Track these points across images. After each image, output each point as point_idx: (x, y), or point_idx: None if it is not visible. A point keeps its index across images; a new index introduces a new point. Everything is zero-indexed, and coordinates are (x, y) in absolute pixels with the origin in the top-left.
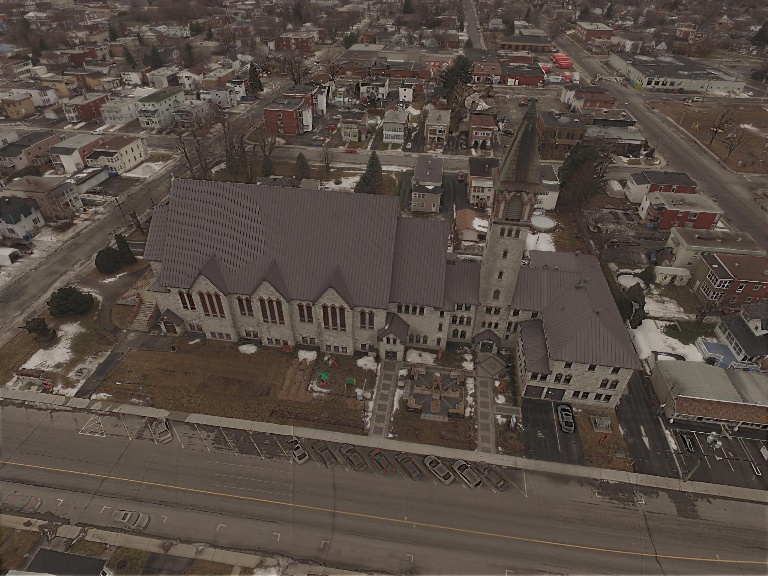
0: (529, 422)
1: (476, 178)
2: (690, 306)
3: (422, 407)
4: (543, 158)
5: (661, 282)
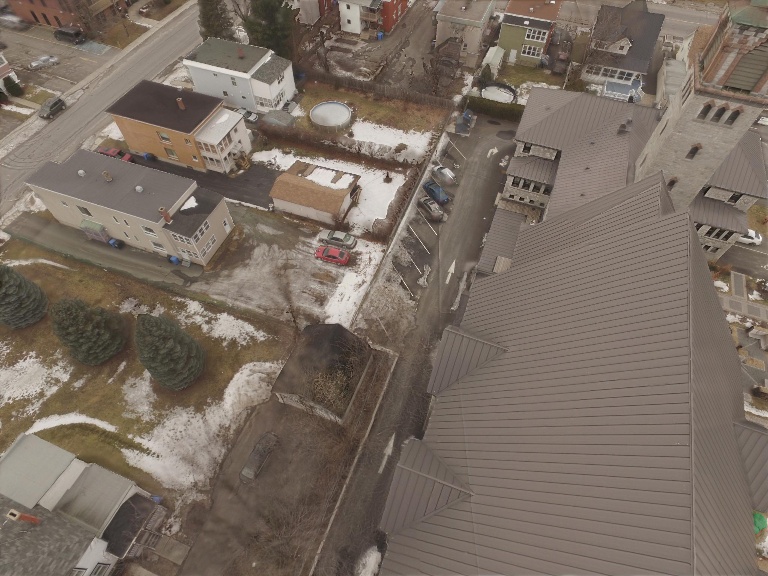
0: (751, 271)
1: (196, 130)
2: (538, 76)
3: (764, 380)
4: (121, 45)
5: (495, 76)
